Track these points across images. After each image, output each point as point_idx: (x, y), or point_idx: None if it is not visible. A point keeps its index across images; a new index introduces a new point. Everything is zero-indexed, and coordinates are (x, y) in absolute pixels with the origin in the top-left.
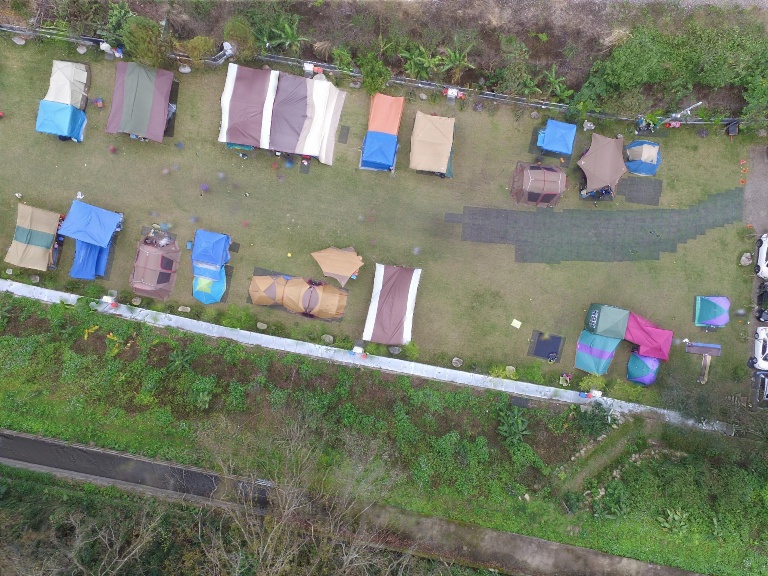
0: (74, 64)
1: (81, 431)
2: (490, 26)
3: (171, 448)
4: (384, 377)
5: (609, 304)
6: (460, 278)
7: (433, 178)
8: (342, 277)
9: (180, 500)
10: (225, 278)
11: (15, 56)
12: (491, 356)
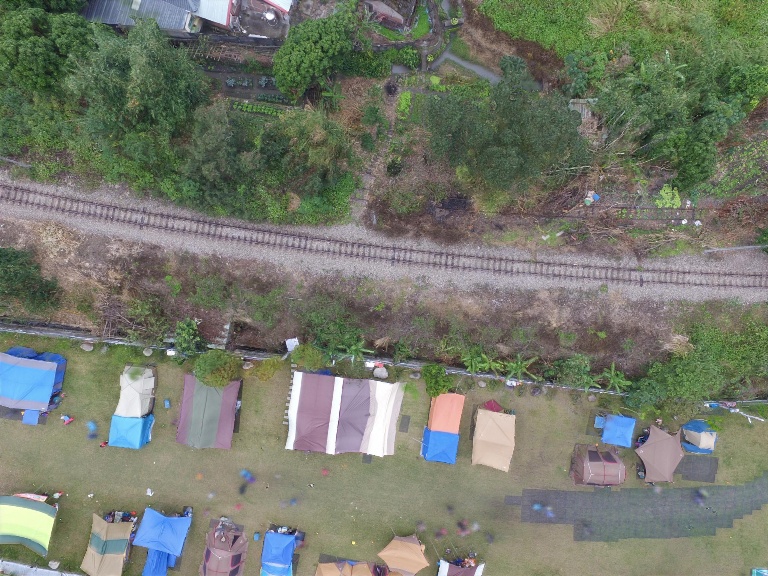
0: (143, 376)
1: None
2: (550, 328)
3: None
4: None
5: None
6: (520, 558)
7: None
8: (407, 573)
9: None
10: (291, 566)
11: (83, 360)
12: None
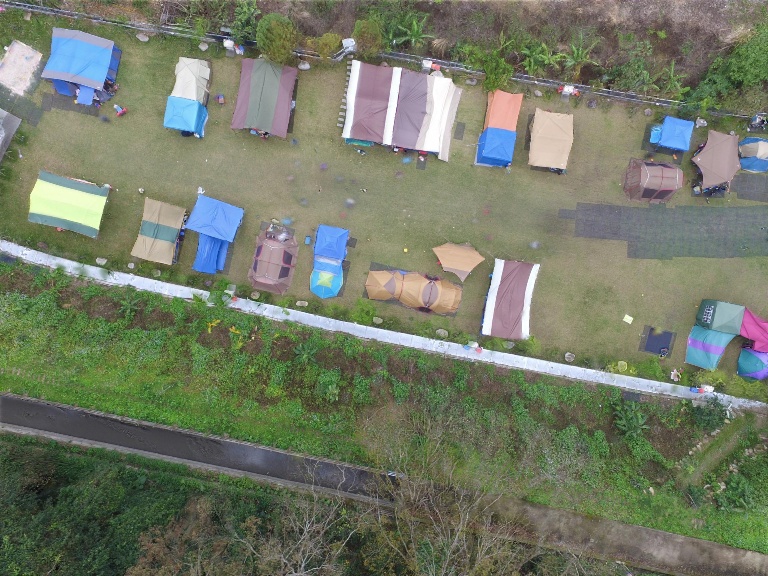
0: (200, 61)
1: (215, 423)
2: (610, 23)
3: (303, 440)
4: (498, 371)
5: (720, 300)
6: (573, 274)
7: (547, 174)
8: (462, 272)
9: (311, 491)
10: (342, 273)
11: (138, 53)
12: (603, 351)
